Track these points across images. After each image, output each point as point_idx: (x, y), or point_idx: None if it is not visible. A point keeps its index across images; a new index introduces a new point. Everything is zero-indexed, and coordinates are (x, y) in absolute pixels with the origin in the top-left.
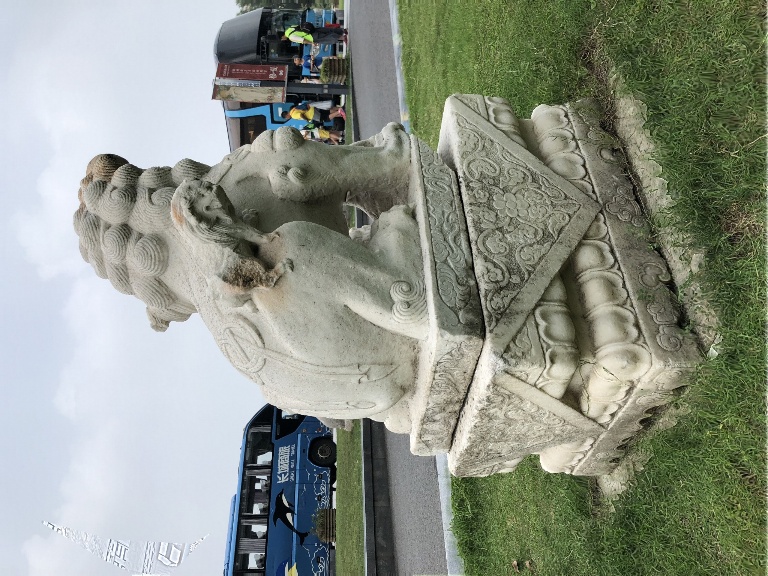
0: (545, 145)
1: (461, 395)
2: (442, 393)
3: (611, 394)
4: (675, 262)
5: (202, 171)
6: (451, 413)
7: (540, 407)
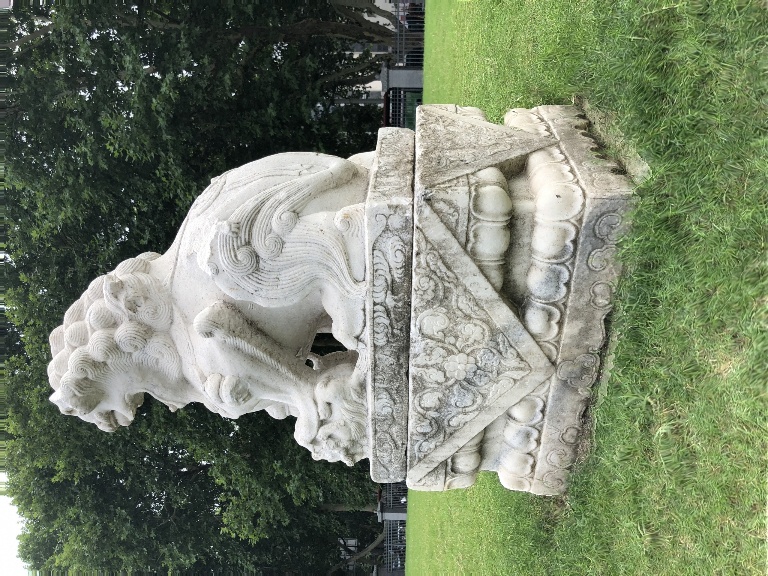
0: None
1: (409, 158)
2: (391, 156)
3: (528, 121)
4: None
5: None
6: (405, 172)
7: (473, 125)
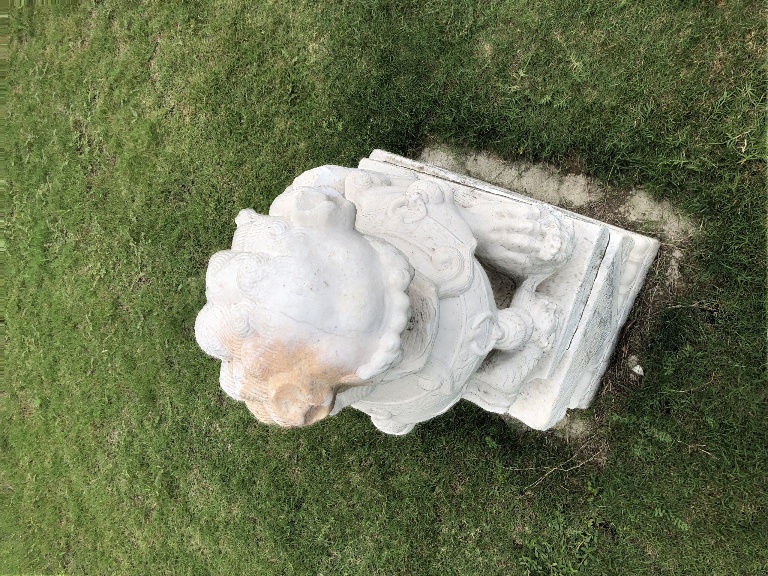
0: None
1: None
2: None
3: None
4: None
5: None
6: None
7: None
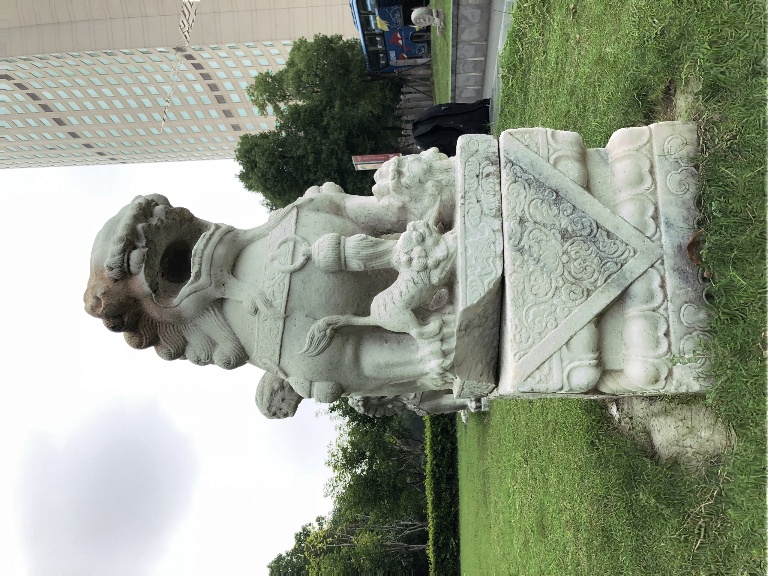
0: (609, 385)
1: None
2: None
3: None
4: (638, 405)
5: (244, 361)
6: None
7: None
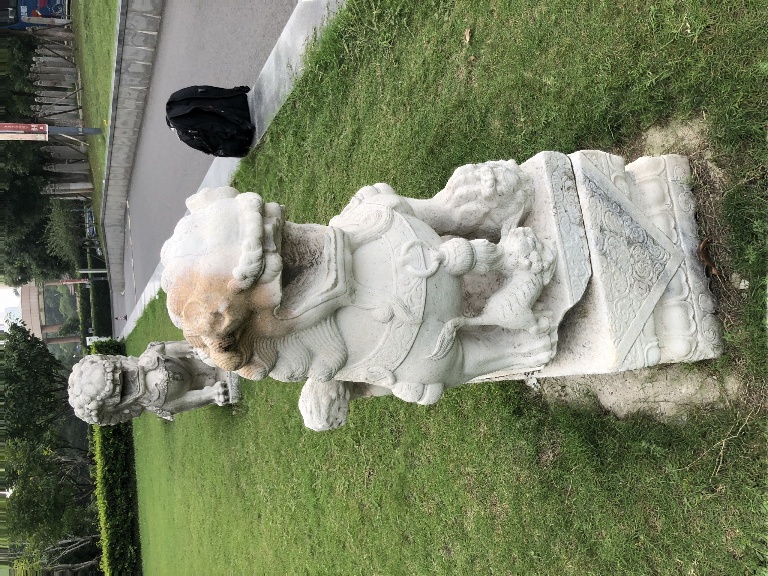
0: None
1: None
2: None
3: None
4: None
5: None
6: None
7: None
